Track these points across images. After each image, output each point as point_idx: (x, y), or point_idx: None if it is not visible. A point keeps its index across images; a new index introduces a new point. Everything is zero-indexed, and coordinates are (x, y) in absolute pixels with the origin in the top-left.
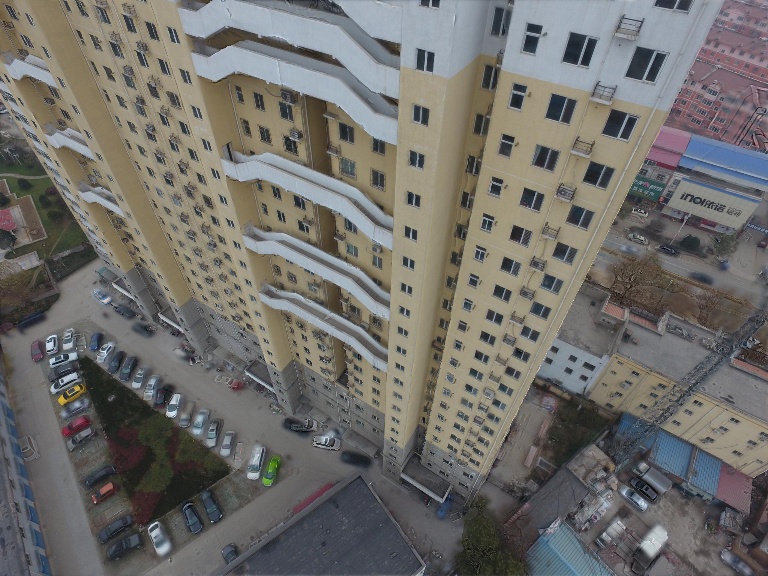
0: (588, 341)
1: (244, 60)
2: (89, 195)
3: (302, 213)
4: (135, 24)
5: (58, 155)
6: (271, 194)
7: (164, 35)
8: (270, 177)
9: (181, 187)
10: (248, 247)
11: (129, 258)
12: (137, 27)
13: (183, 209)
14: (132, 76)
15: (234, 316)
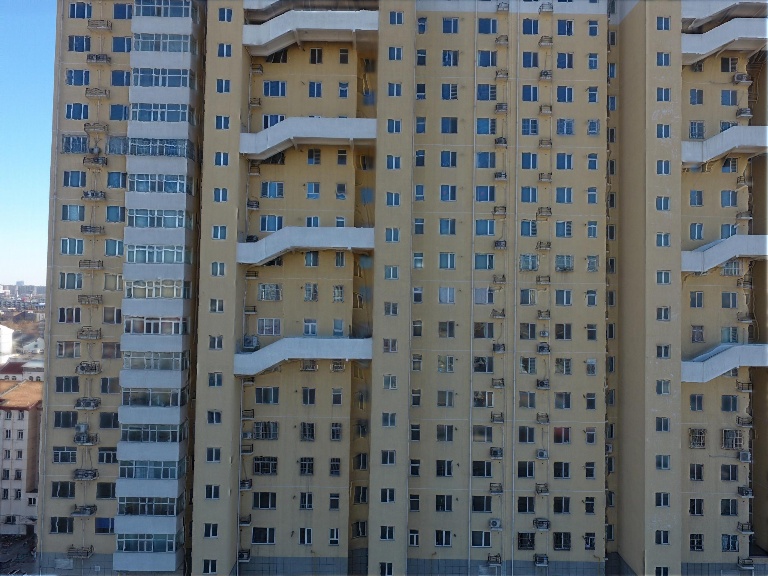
0: None
1: (750, 26)
2: (275, 349)
3: (732, 211)
4: (543, 57)
5: (237, 282)
6: (689, 202)
7: (651, 24)
8: (754, 138)
9: (514, 259)
10: (685, 269)
11: (235, 536)
12: (543, 60)
13: (494, 305)
14: (506, 113)
15: (527, 533)
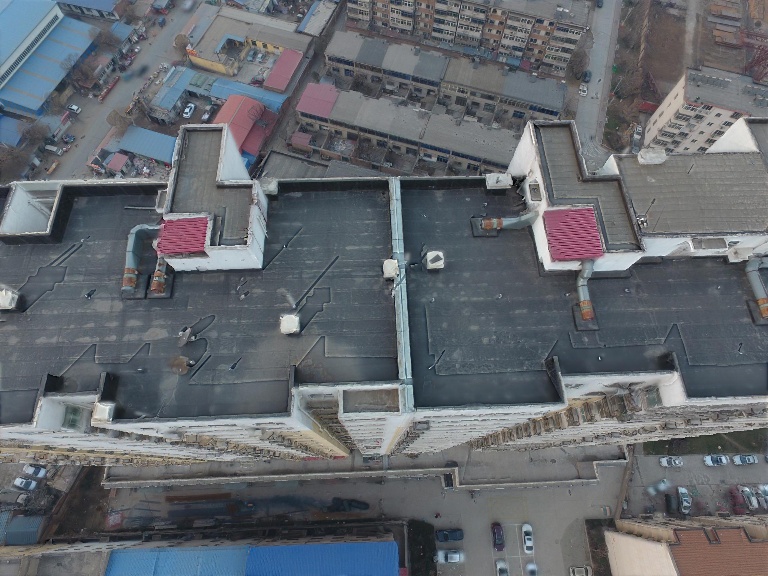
0: (59, 574)
1: None
2: None
3: None
4: None
5: None
6: None
7: None
8: None
9: None
10: None
11: None
12: None
13: None
14: None
15: None
